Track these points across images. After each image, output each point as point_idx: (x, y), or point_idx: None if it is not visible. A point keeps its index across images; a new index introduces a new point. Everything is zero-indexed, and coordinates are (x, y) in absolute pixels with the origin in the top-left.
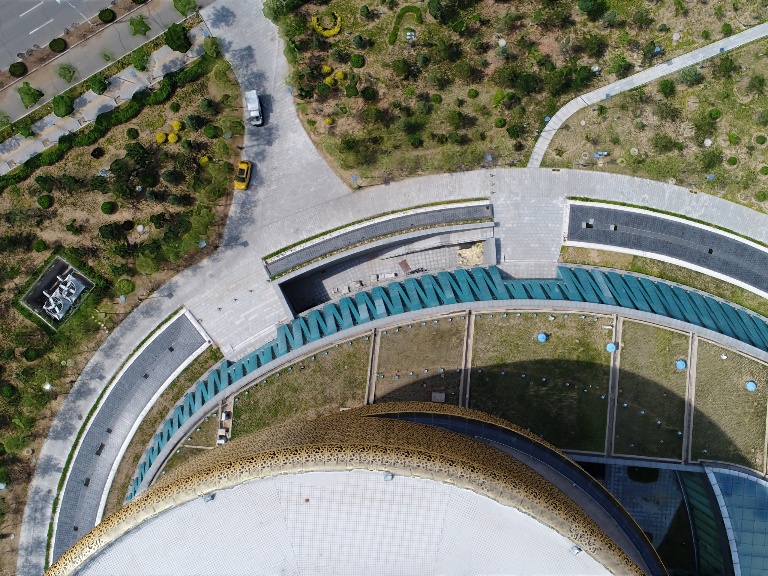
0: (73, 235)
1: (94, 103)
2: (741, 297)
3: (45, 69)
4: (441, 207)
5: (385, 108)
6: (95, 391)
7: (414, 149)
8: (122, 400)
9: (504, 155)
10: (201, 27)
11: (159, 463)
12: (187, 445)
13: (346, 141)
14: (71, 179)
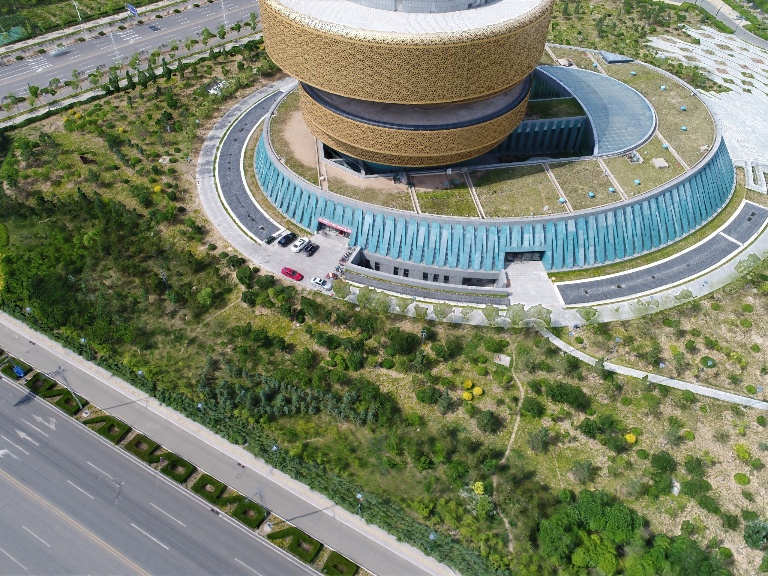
0: (223, 74)
1: (230, 46)
2: None
3: None
4: None
5: None
6: (237, 114)
7: None
8: (252, 115)
9: None
10: None
11: (283, 97)
12: (295, 91)
13: None
14: (225, 50)
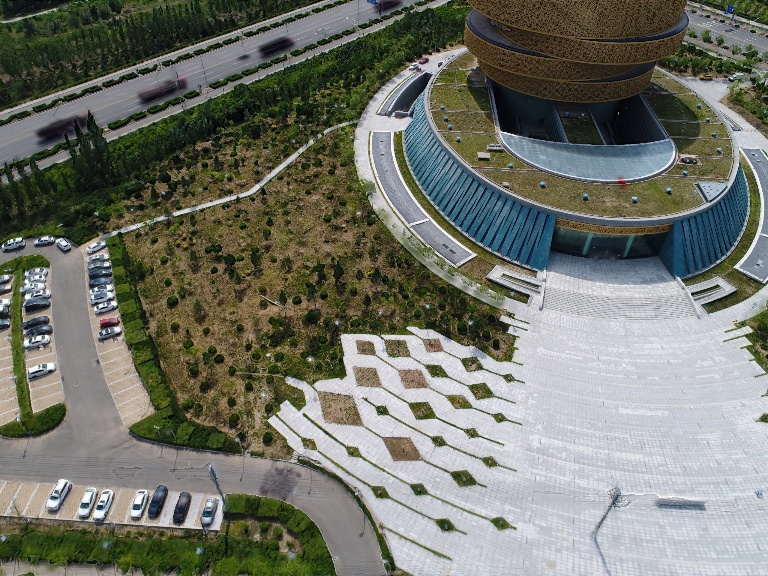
0: None
1: (709, 53)
2: (755, 198)
3: (714, 46)
4: (729, 119)
5: (763, 105)
6: None
7: (750, 112)
8: None
9: (767, 133)
10: (759, 70)
11: None
12: None
13: (741, 92)
14: None
